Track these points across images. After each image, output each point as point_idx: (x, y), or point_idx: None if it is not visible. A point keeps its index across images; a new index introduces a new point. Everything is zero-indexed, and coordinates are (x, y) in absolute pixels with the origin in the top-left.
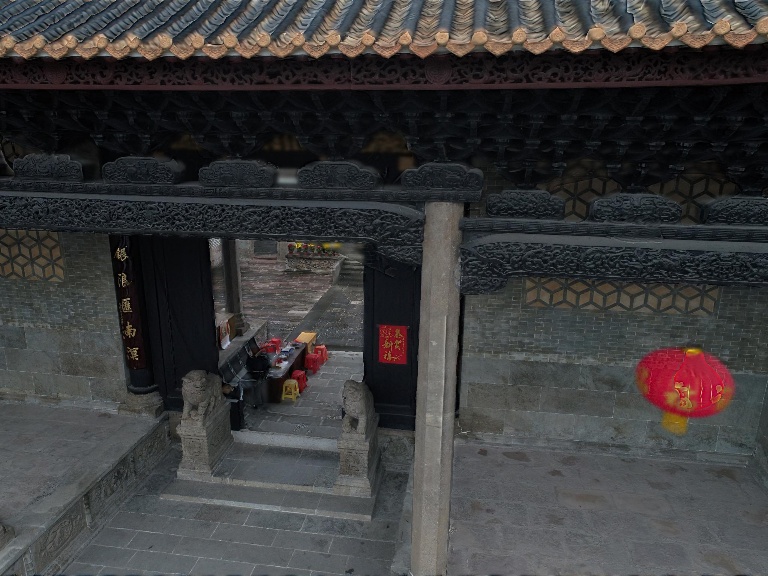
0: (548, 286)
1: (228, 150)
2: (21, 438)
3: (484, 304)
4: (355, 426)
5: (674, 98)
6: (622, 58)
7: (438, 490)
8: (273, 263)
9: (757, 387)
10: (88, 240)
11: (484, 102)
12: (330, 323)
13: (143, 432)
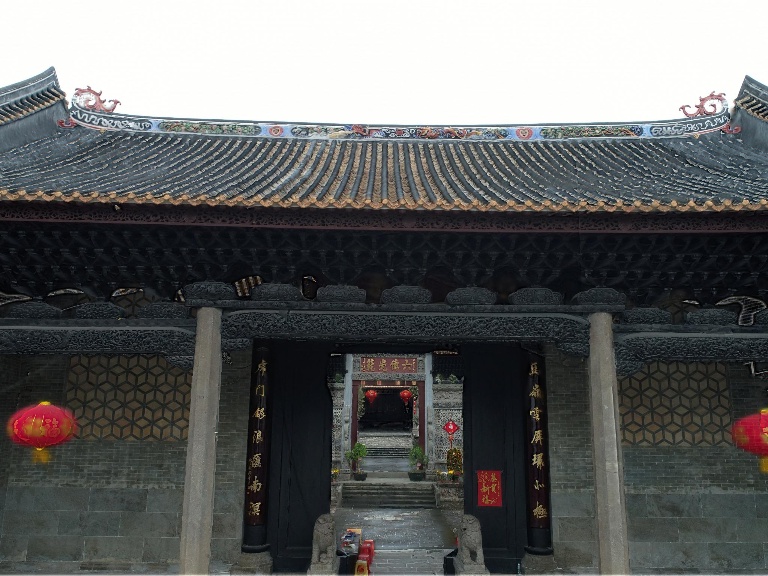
0: None
1: (473, 279)
2: None
3: (564, 445)
4: (474, 558)
5: (735, 243)
6: (714, 219)
7: (621, 528)
8: None
9: None
10: (230, 403)
11: (639, 245)
12: None
13: None
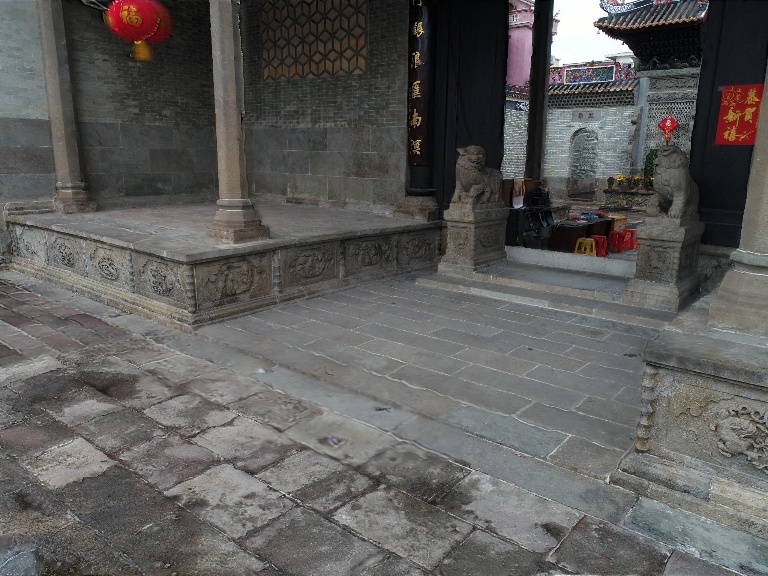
0: None
1: None
2: (305, 216)
3: None
4: (666, 209)
5: None
6: None
7: None
8: (588, 204)
9: None
10: (390, 21)
11: None
12: None
13: (412, 224)
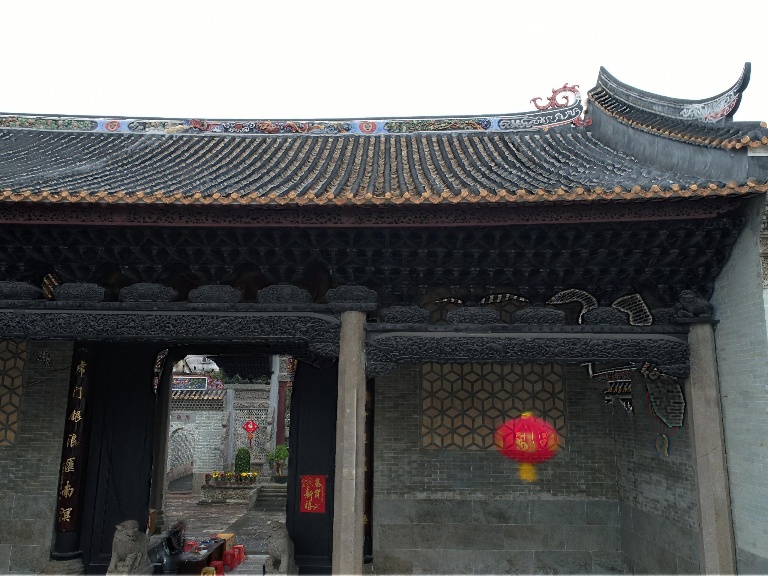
0: (439, 431)
1: (213, 277)
2: None
3: (389, 449)
4: (277, 567)
5: (475, 237)
6: (443, 212)
7: (353, 538)
8: (187, 497)
9: (612, 511)
10: (47, 405)
11: (374, 240)
12: (246, 537)
13: None
